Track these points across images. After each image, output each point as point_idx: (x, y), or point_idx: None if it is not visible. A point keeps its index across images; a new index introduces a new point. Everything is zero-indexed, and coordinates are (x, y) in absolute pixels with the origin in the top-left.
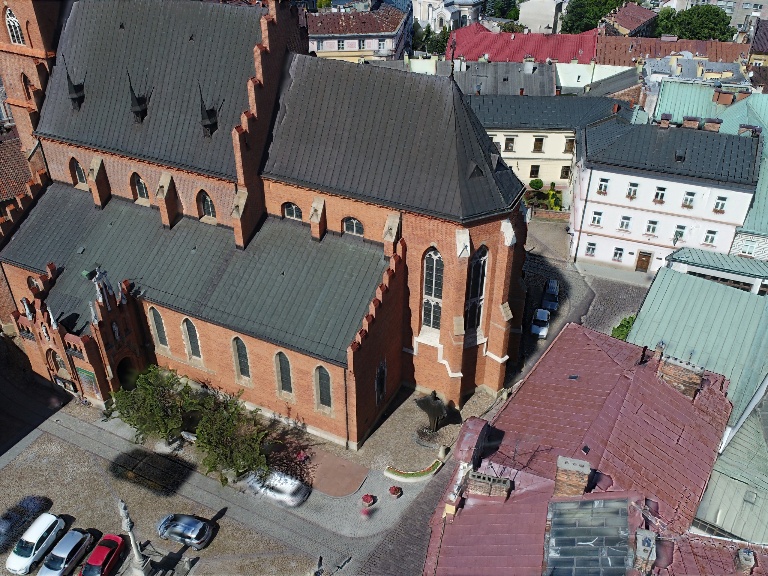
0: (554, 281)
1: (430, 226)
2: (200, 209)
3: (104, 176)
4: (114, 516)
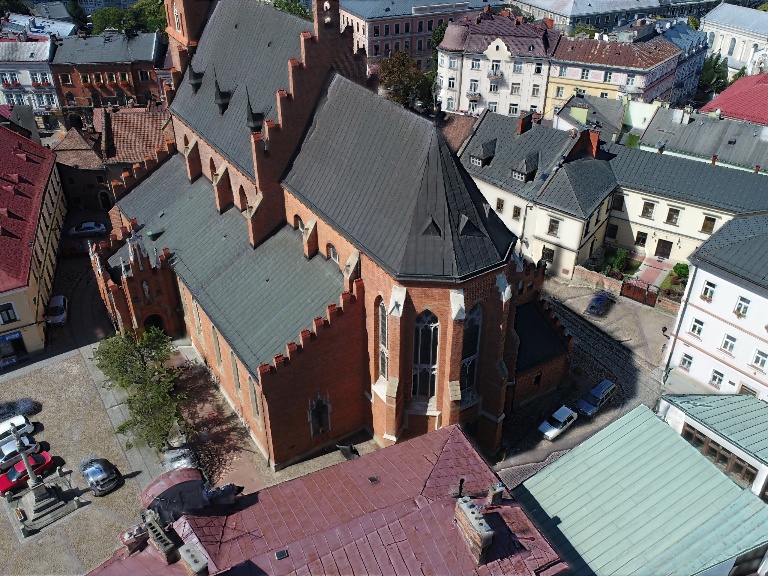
0: (608, 382)
1: (378, 274)
2: (244, 202)
3: (198, 155)
4: (67, 440)
